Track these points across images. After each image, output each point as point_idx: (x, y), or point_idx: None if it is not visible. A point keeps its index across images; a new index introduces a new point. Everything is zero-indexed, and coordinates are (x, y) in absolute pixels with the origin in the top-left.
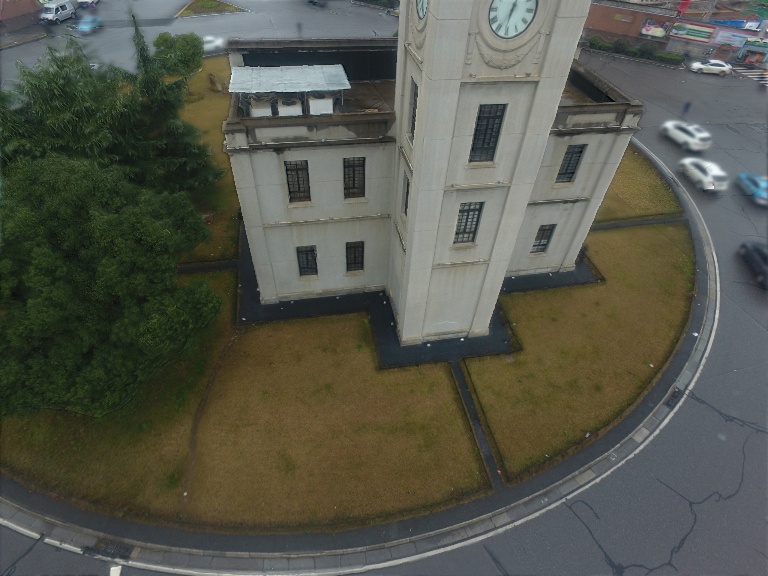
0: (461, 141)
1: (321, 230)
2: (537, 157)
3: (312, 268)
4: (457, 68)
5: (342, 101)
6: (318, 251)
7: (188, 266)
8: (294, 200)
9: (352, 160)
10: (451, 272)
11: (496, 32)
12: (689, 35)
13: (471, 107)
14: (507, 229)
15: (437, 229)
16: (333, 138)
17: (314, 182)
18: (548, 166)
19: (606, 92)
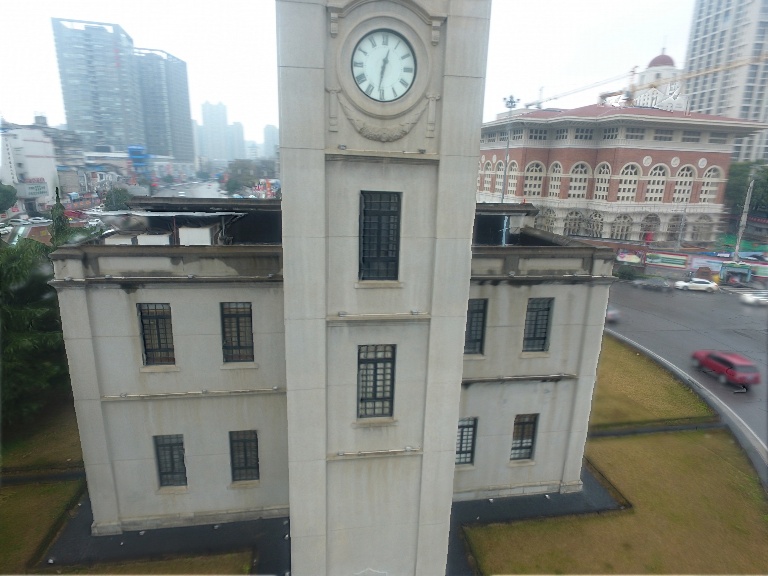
0: (342, 244)
1: (191, 410)
2: (461, 274)
3: (180, 474)
4: (316, 134)
5: (223, 232)
6: (187, 444)
7: (24, 475)
8: (152, 362)
9: (235, 307)
10: (362, 470)
11: (367, 94)
12: (664, 263)
13: (348, 194)
14: (440, 393)
15: (324, 387)
16: (206, 275)
17: (179, 335)
18: (507, 326)
19: (566, 245)
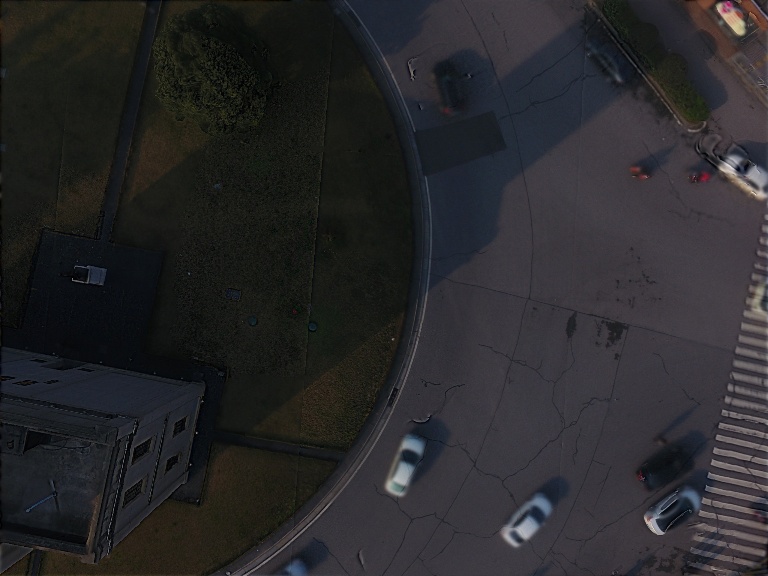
0: None
1: None
2: None
3: None
4: None
5: None
6: None
7: None
8: None
9: None
10: None
11: None
12: None
13: None
14: None
15: None
16: None
17: None
18: None
19: None
